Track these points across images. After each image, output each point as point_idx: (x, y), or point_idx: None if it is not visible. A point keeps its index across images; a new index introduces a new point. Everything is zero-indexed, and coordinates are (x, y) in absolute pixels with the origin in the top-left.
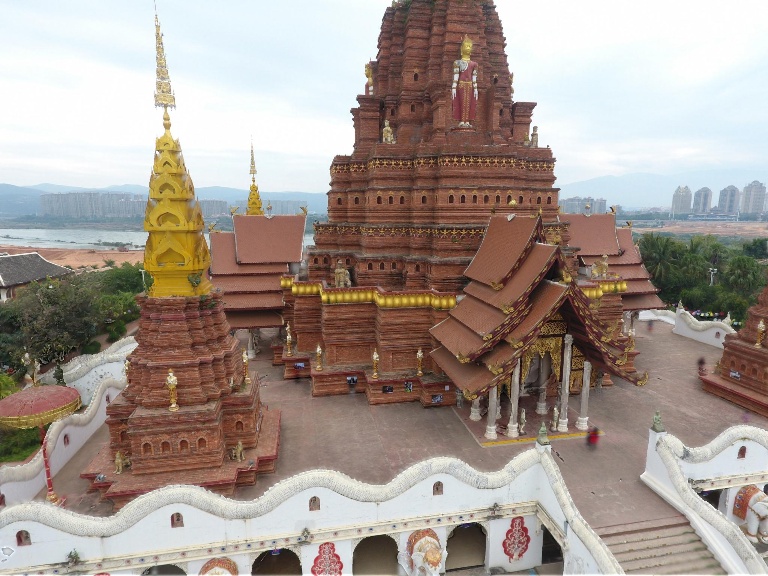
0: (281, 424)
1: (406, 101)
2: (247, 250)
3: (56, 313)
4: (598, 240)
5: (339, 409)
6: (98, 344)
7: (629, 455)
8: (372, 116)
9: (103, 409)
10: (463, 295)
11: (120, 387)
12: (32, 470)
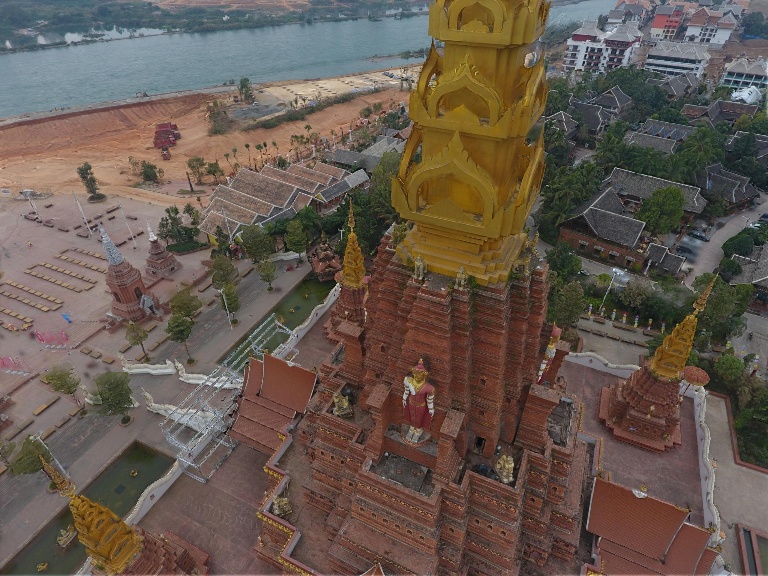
0: None
1: None
2: None
3: None
4: None
5: None
6: None
7: None
8: None
9: None
10: (598, 549)
11: None
12: None
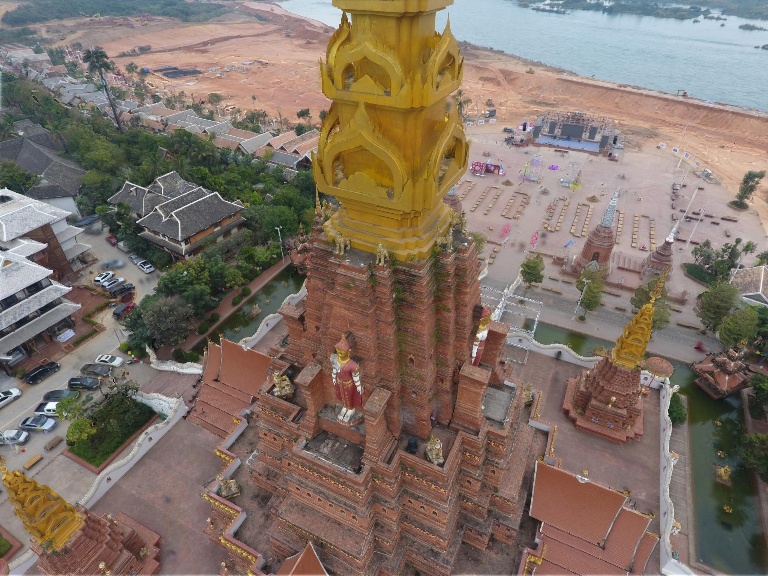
0: (163, 567)
1: (306, 349)
2: (227, 371)
3: (154, 334)
4: (580, 514)
5: (205, 571)
6: (216, 316)
7: None
8: (296, 328)
9: (102, 488)
10: None
11: (125, 464)
12: (27, 558)
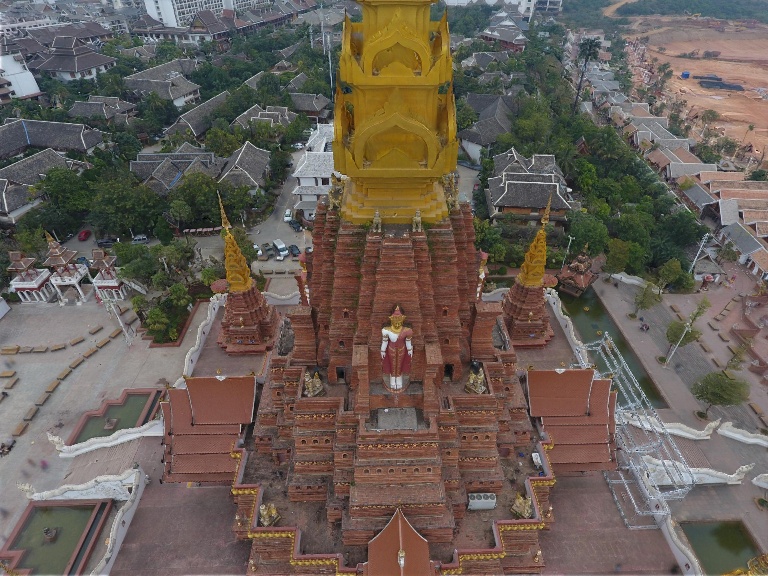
0: None
1: None
2: None
3: None
4: None
5: None
6: None
7: (166, 486)
8: None
9: (295, 300)
10: None
11: None
12: None
